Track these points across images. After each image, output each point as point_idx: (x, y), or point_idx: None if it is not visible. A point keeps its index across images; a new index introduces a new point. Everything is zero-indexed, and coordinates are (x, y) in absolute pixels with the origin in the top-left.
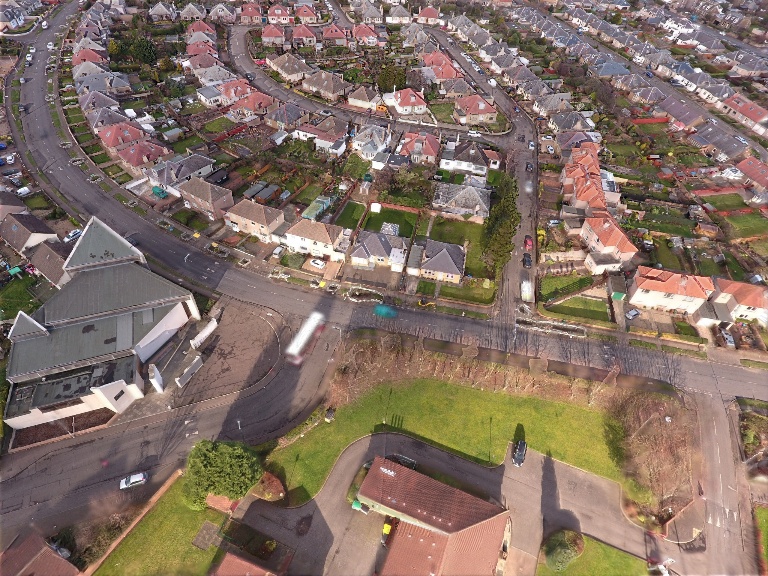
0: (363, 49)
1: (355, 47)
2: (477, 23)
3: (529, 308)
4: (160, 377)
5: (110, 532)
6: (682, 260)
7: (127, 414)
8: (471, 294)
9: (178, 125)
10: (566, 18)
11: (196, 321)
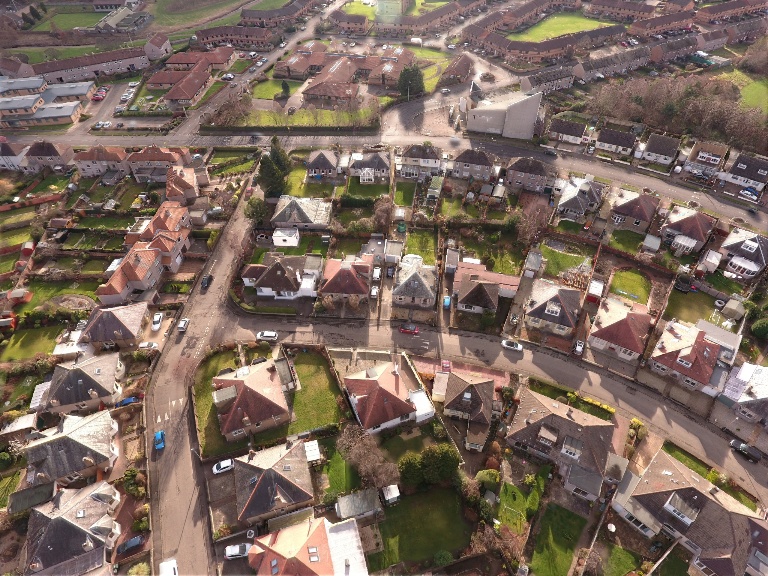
0: None
1: None
2: None
3: (267, 152)
4: None
5: None
6: (120, 196)
7: None
8: None
9: None
10: None
11: None
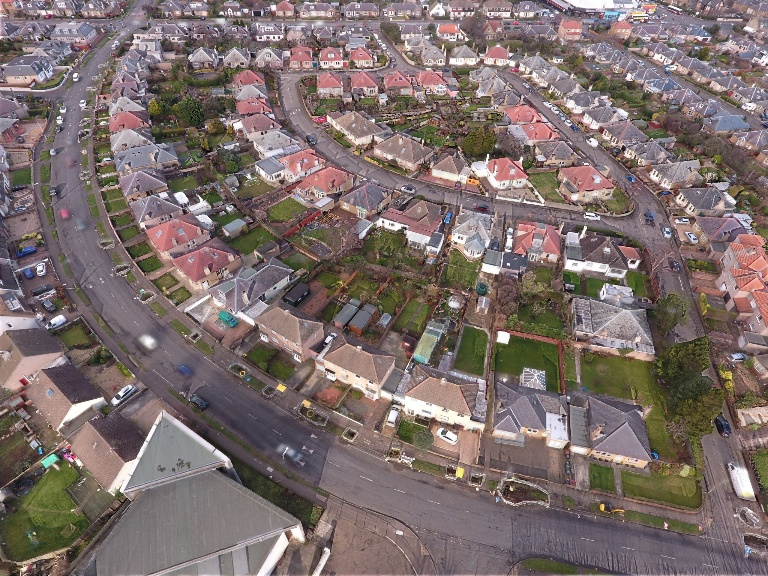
0: (433, 100)
1: (423, 98)
2: (549, 62)
3: (755, 515)
4: None
5: None
6: None
7: None
8: (666, 488)
9: (238, 211)
10: (645, 53)
11: (299, 544)
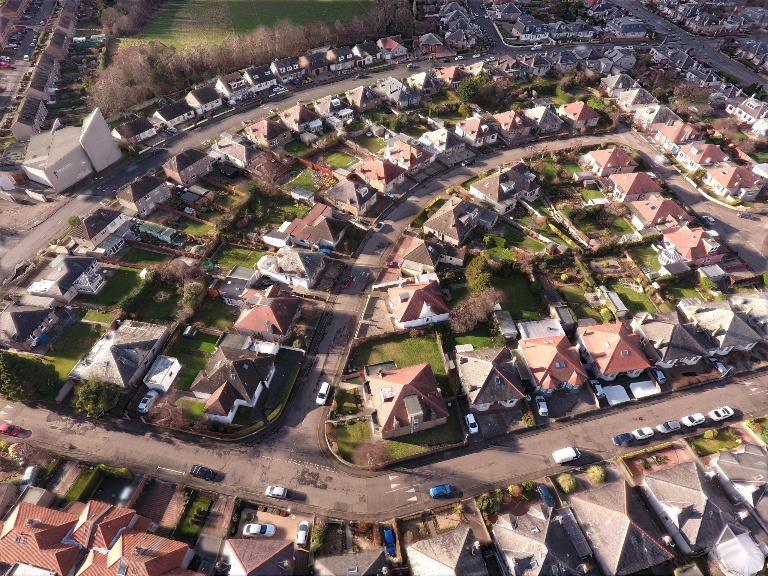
0: (623, 249)
1: (627, 239)
2: None
3: None
4: (9, 186)
5: None
6: None
7: None
8: None
9: None
10: None
11: None
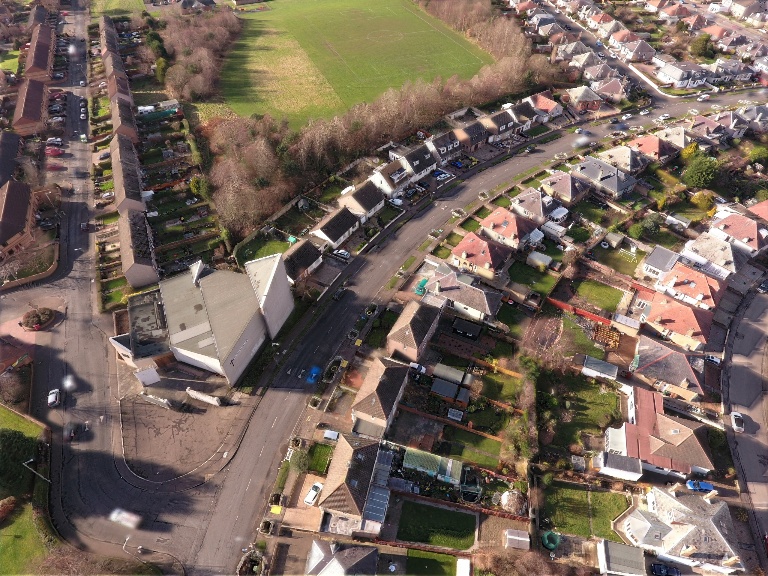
0: None
1: None
2: None
3: None
4: (153, 378)
5: (2, 398)
6: None
7: (126, 369)
8: None
9: None
10: None
11: None
